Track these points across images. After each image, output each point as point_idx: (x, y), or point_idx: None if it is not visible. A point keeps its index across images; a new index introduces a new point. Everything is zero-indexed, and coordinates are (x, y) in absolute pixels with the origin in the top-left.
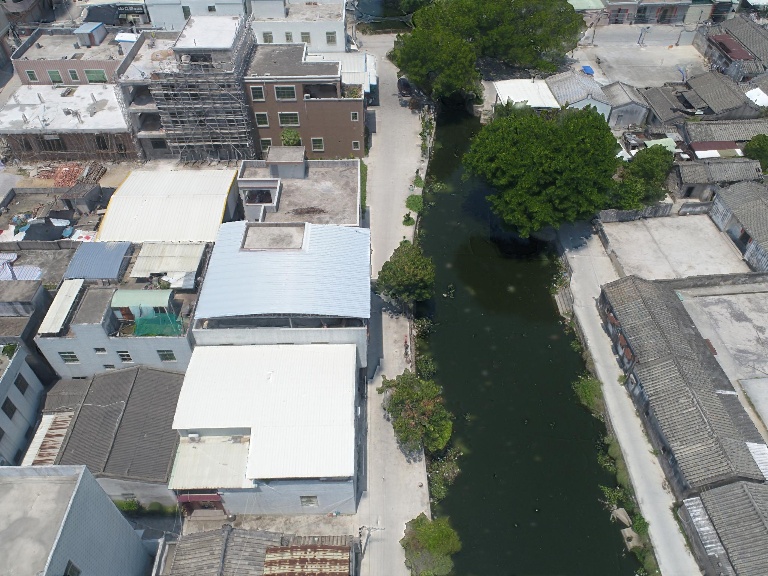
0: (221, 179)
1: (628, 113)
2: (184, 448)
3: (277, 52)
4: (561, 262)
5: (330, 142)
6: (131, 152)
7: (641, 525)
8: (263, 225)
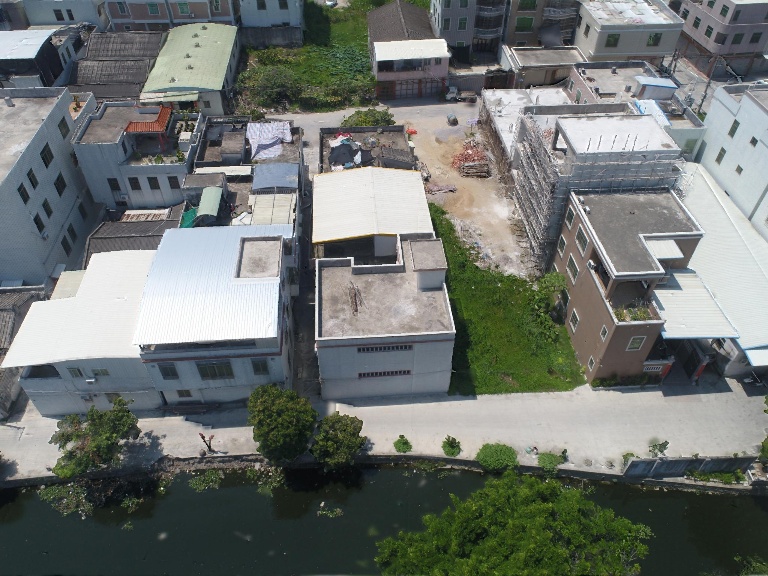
0: (411, 227)
1: None
2: None
3: (663, 211)
4: None
5: (581, 332)
6: None
7: None
8: None
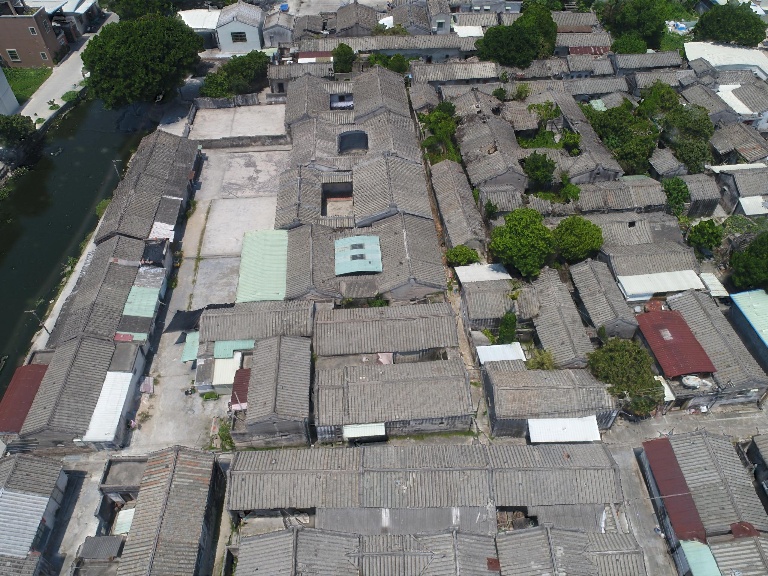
0: None
1: (277, 35)
2: None
3: None
4: None
5: (23, 53)
6: None
7: (69, 272)
8: None
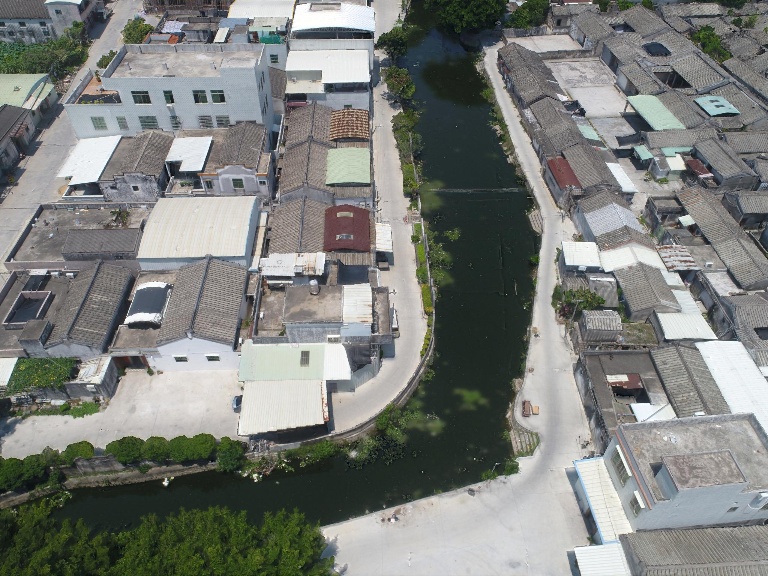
0: (289, 1)
1: None
2: (290, 84)
3: None
4: (481, 54)
5: None
6: (225, 6)
7: (504, 126)
8: (319, 4)
